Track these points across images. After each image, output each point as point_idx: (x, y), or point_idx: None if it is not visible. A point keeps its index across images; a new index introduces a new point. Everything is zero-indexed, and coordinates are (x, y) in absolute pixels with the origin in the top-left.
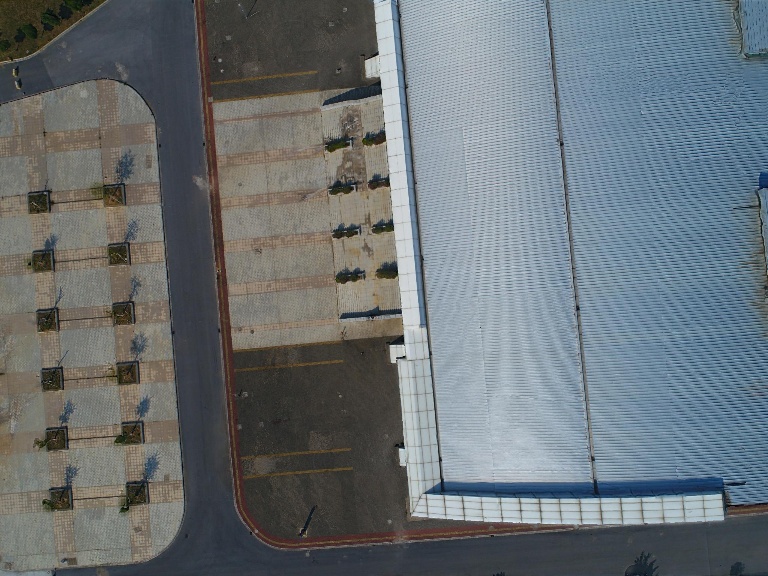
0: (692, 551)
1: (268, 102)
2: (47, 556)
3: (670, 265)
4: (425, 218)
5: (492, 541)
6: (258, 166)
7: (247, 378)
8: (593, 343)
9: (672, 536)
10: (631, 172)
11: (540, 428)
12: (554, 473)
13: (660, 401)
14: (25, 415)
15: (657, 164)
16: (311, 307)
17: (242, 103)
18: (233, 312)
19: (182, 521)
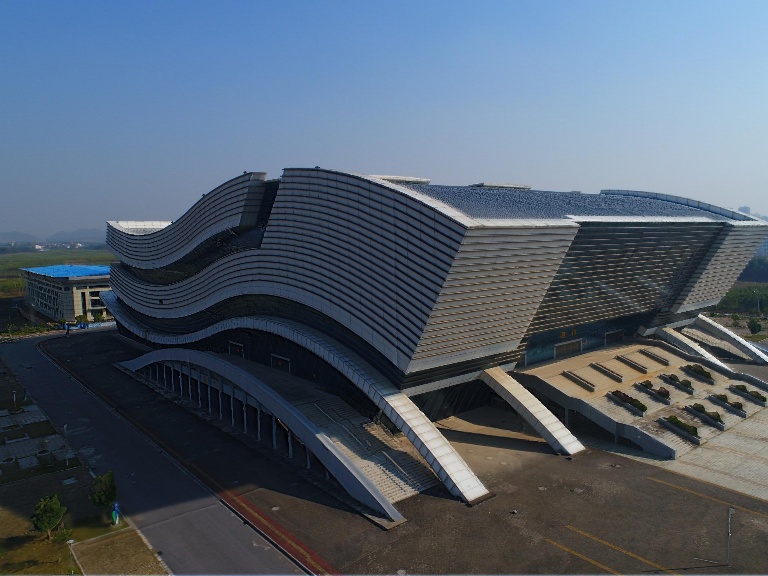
0: None
1: (760, 495)
2: None
3: None
4: None
5: None
6: None
7: None
8: None
9: None
10: None
11: None
12: None
13: None
14: None
15: None
16: None
17: None
18: None
19: None
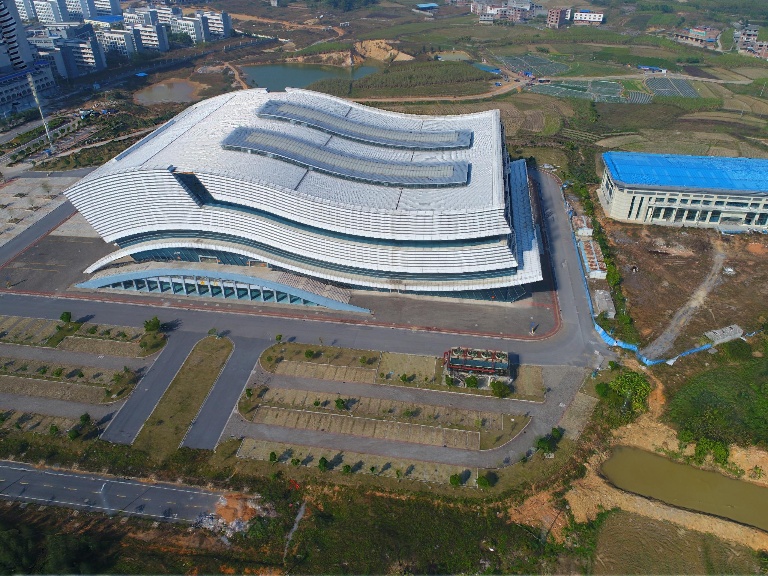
0: (206, 322)
1: None
2: None
3: None
4: None
5: None
6: None
7: (44, 242)
8: None
9: None
10: None
11: None
12: None
13: None
14: None
15: None
16: None
17: None
18: (61, 226)
19: None
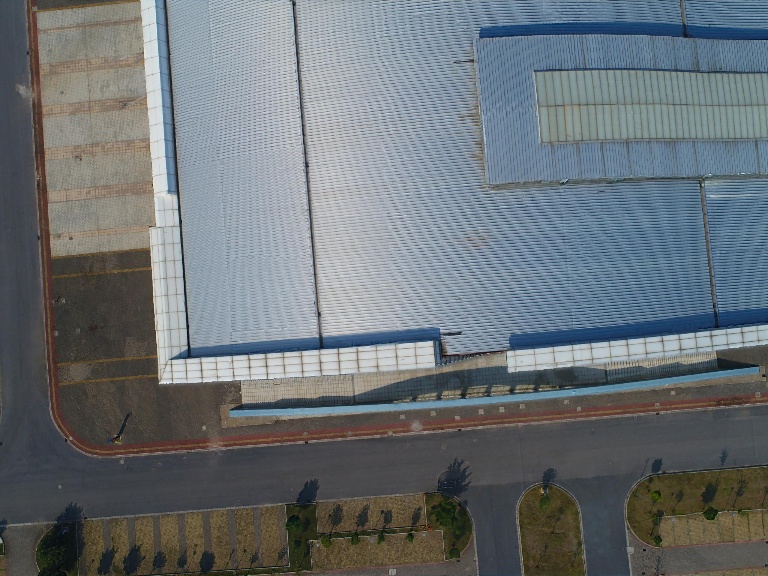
0: (505, 457)
1: (91, 11)
2: None
3: (392, 118)
4: (176, 86)
5: (306, 448)
6: (80, 74)
7: (65, 285)
8: (320, 198)
9: (485, 442)
10: (356, 28)
11: (272, 286)
12: (284, 330)
13: (381, 253)
14: None
15: (381, 20)
16: (130, 214)
17: (66, 12)
18: (52, 219)
19: None
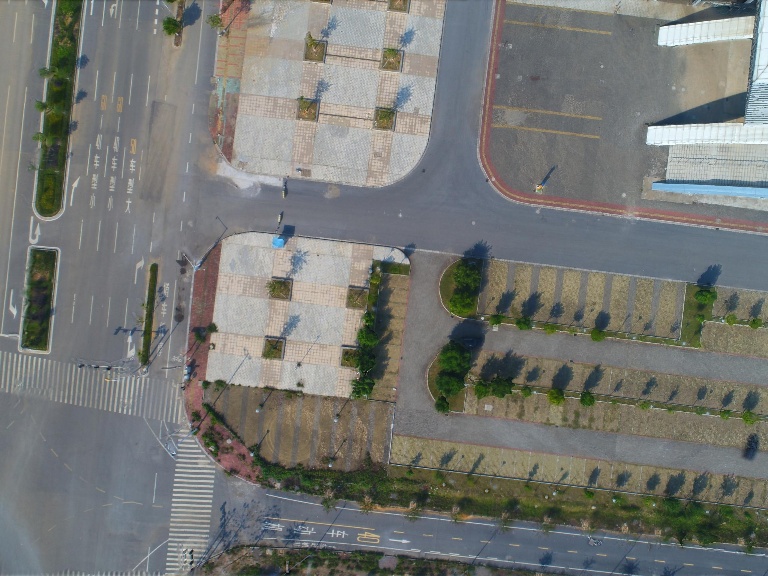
0: None
1: None
2: (282, 163)
3: None
4: None
5: (716, 234)
6: None
7: (515, 31)
8: None
9: None
10: None
11: None
12: None
13: None
14: (288, 22)
15: None
16: None
17: None
18: None
19: (423, 155)
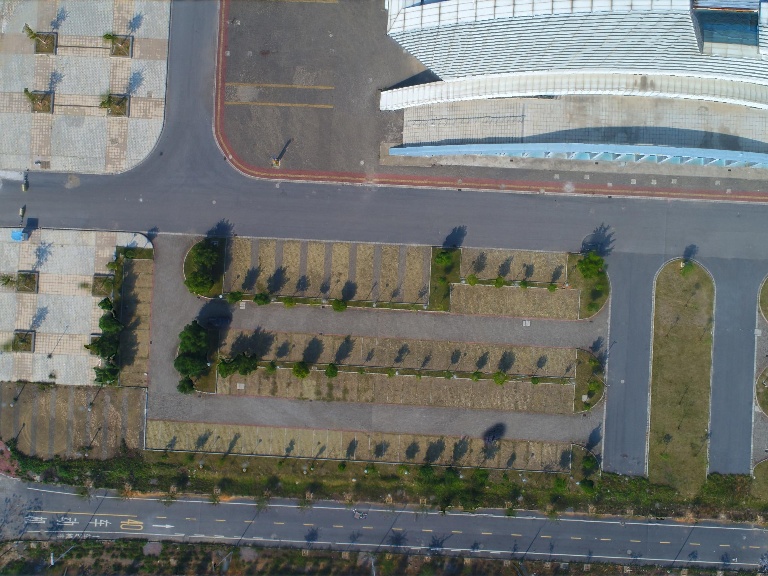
0: (650, 228)
1: None
2: (21, 157)
3: None
4: None
5: (459, 195)
6: None
7: (242, 7)
8: None
9: (633, 212)
10: None
11: None
12: None
13: None
14: (17, 16)
15: None
16: None
17: None
18: None
19: (159, 139)
